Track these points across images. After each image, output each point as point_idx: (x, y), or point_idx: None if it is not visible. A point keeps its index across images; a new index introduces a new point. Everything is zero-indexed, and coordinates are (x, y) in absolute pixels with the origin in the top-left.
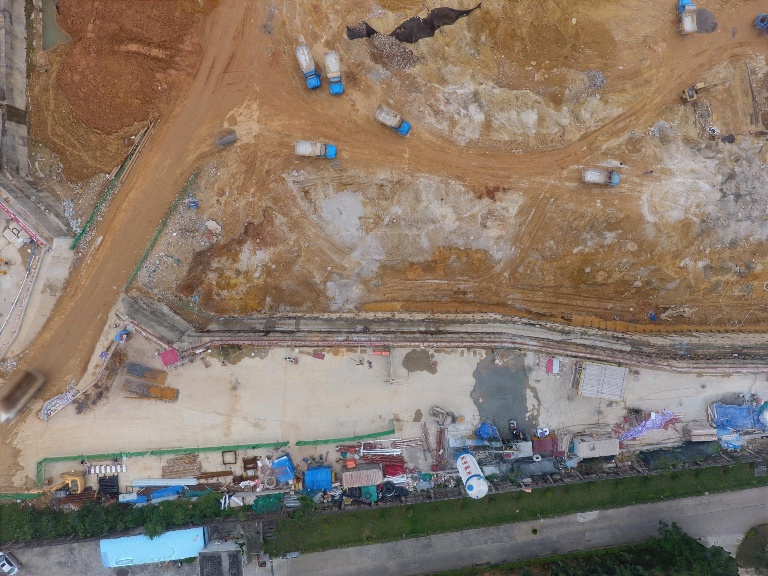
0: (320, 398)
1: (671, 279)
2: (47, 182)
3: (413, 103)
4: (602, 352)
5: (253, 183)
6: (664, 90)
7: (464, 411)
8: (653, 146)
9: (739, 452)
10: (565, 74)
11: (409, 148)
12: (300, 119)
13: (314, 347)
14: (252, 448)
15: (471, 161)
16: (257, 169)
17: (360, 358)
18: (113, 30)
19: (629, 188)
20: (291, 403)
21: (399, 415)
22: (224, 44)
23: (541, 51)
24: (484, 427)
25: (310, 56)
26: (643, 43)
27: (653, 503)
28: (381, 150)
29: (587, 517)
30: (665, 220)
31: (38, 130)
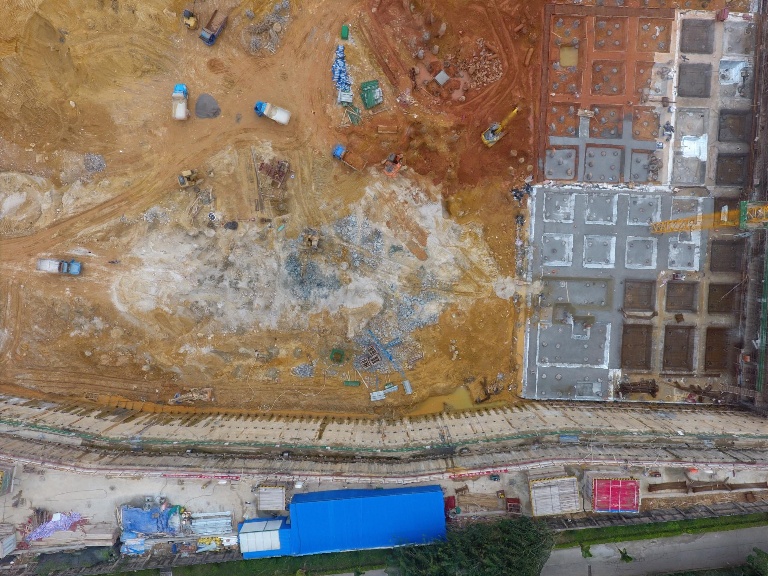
0: None
1: (167, 366)
2: None
3: None
4: (8, 450)
5: None
6: (166, 175)
7: None
8: (137, 233)
9: (139, 557)
10: (61, 157)
11: None
12: None
13: None
14: None
15: None
16: None
17: None
18: None
19: (98, 277)
20: None
21: None
22: None
23: (41, 133)
24: None
25: None
26: (144, 127)
27: None
28: None
29: None
30: (136, 310)
31: None
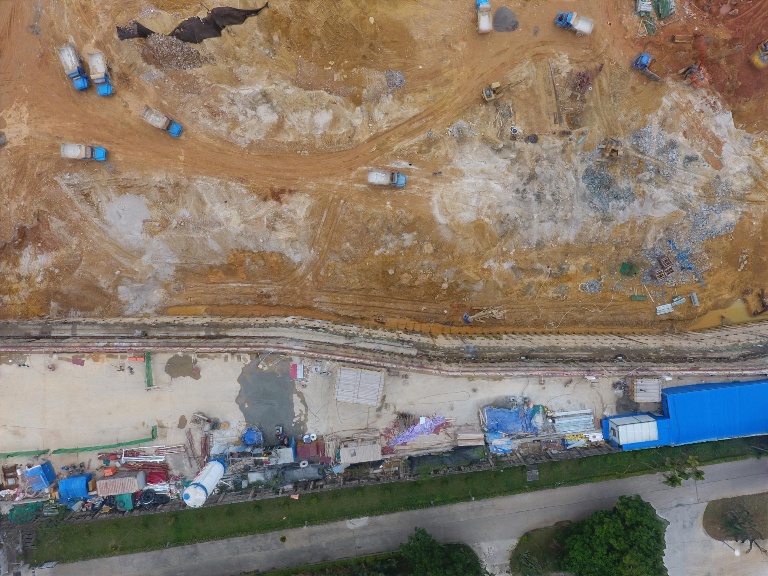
0: (81, 405)
1: (473, 281)
2: None
3: (186, 104)
4: (371, 356)
5: (24, 186)
6: (465, 90)
7: (230, 417)
8: (448, 146)
9: (508, 456)
10: (363, 74)
11: (184, 150)
12: (71, 121)
13: (73, 353)
14: (6, 456)
15: (254, 163)
16: (28, 172)
17: (120, 364)
18: None
19: (419, 189)
20: (51, 410)
21: (163, 421)
22: None
23: (340, 51)
24: (249, 433)
25: (75, 57)
26: (443, 42)
27: (424, 509)
28: (155, 152)
29: (357, 523)
30: (457, 221)
31: None
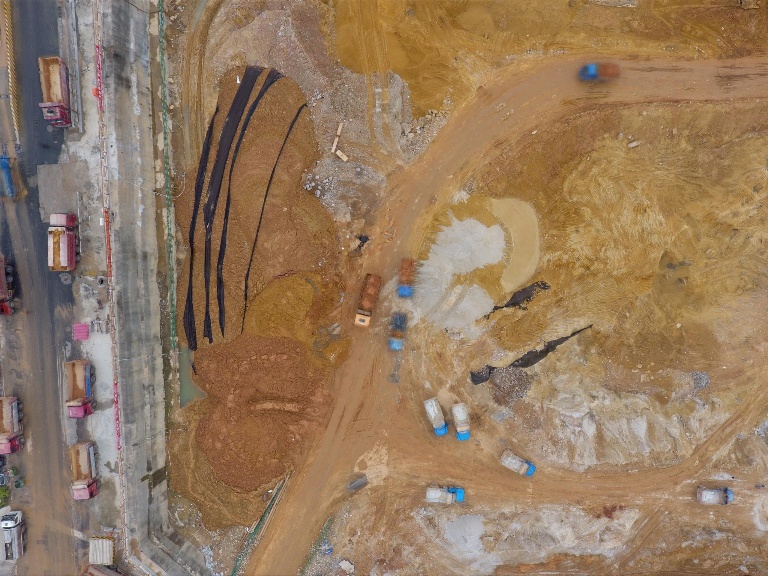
0: None
1: None
2: (187, 530)
3: (536, 442)
4: None
5: (384, 523)
6: (767, 387)
7: None
8: (761, 451)
9: None
10: (671, 377)
11: (533, 483)
12: (428, 461)
13: None
14: None
15: (589, 485)
16: (387, 509)
17: None
18: (250, 394)
19: (741, 500)
20: None
21: None
22: (354, 394)
23: (646, 354)
24: None
25: (439, 408)
26: (746, 343)
27: None
28: (506, 486)
29: None
30: None
31: (178, 484)
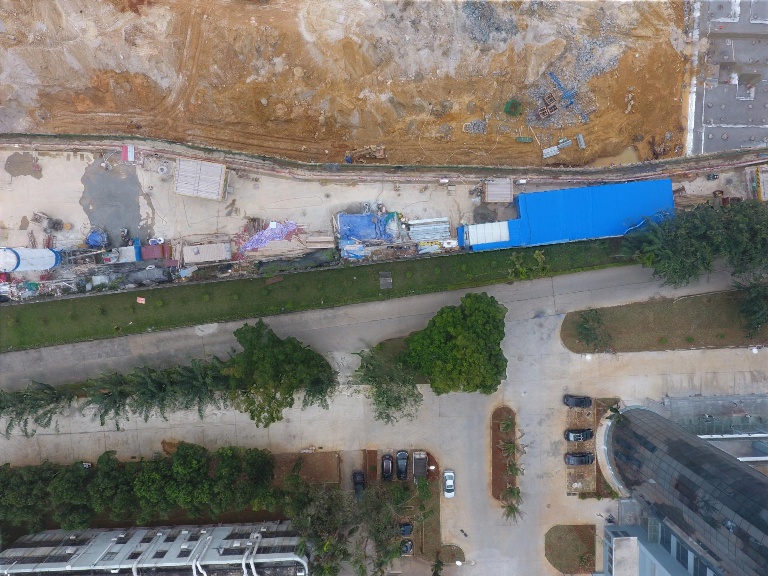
0: None
1: (348, 110)
2: None
3: None
4: None
5: None
6: None
7: (73, 219)
8: None
9: None
10: None
11: None
12: None
13: None
14: None
15: None
16: None
17: None
18: None
19: (284, 4)
20: None
21: (4, 222)
22: None
23: None
24: (93, 235)
25: None
26: None
27: (275, 316)
28: None
29: (206, 330)
30: (324, 39)
31: None
